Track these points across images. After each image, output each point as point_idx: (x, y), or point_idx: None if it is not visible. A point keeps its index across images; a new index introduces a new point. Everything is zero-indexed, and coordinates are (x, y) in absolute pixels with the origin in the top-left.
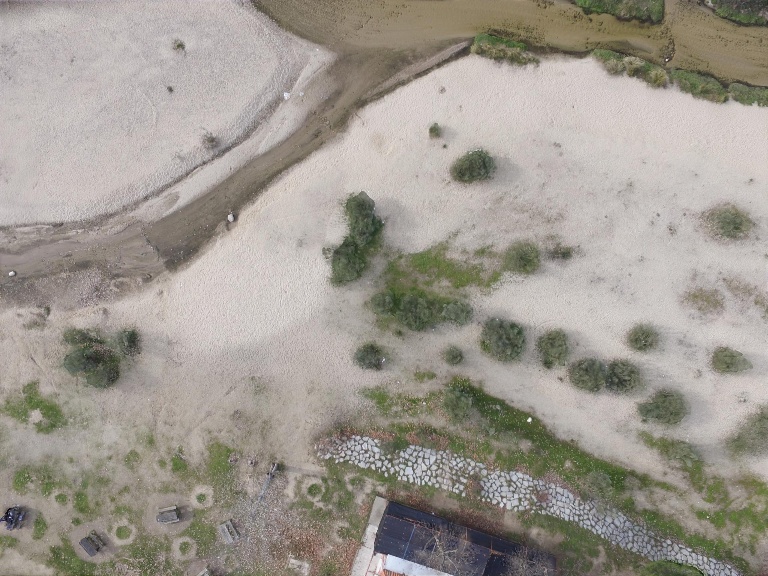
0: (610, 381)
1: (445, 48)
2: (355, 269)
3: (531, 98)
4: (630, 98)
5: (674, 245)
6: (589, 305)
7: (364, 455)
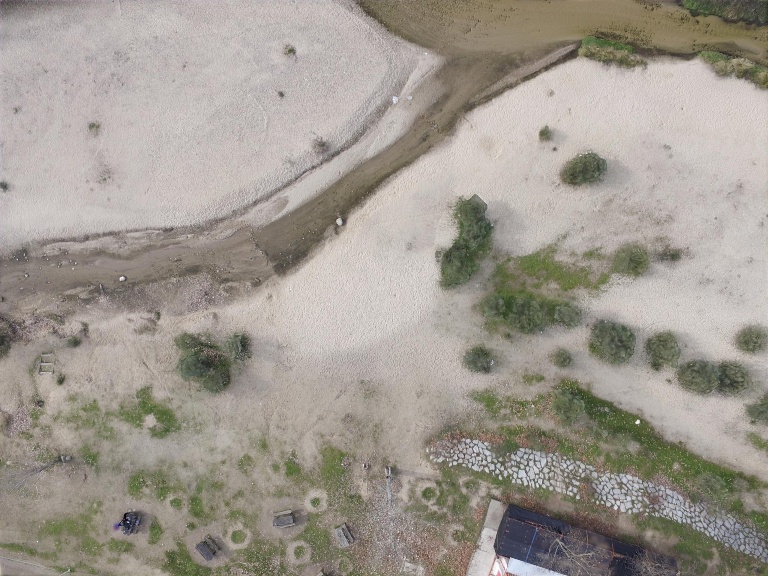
0: (720, 383)
1: (553, 51)
2: (468, 272)
3: (640, 100)
4: (739, 99)
5: None
6: (698, 307)
7: (476, 458)
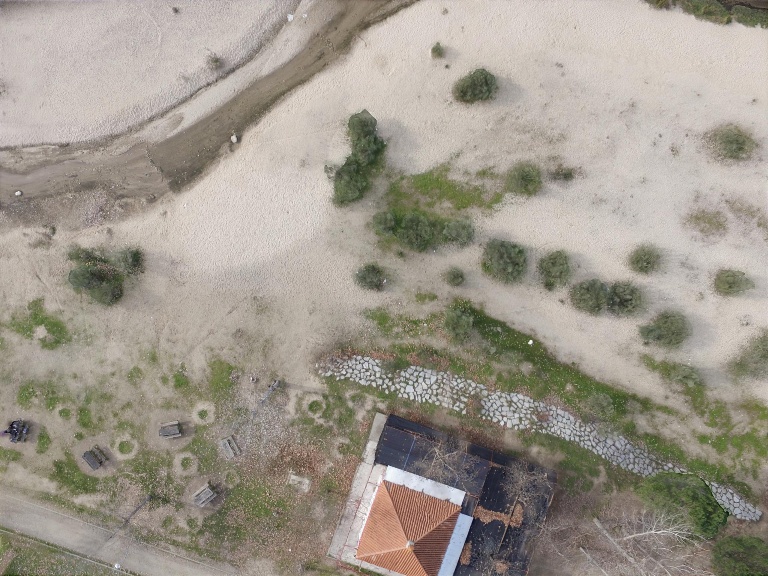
0: (611, 303)
1: None
2: (357, 187)
3: (533, 19)
4: (632, 19)
5: (676, 166)
6: (590, 227)
7: (365, 373)
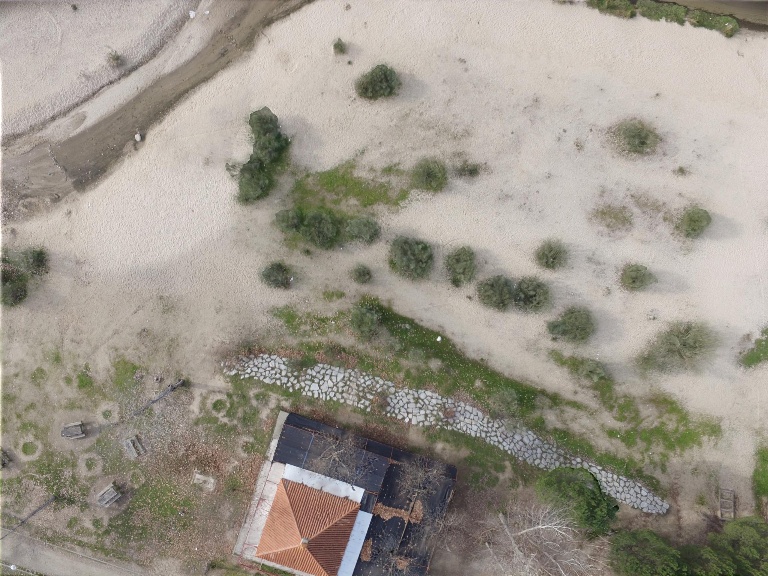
0: (518, 299)
1: None
2: (259, 185)
3: (436, 14)
4: (536, 14)
5: (581, 161)
6: (497, 223)
7: (270, 372)
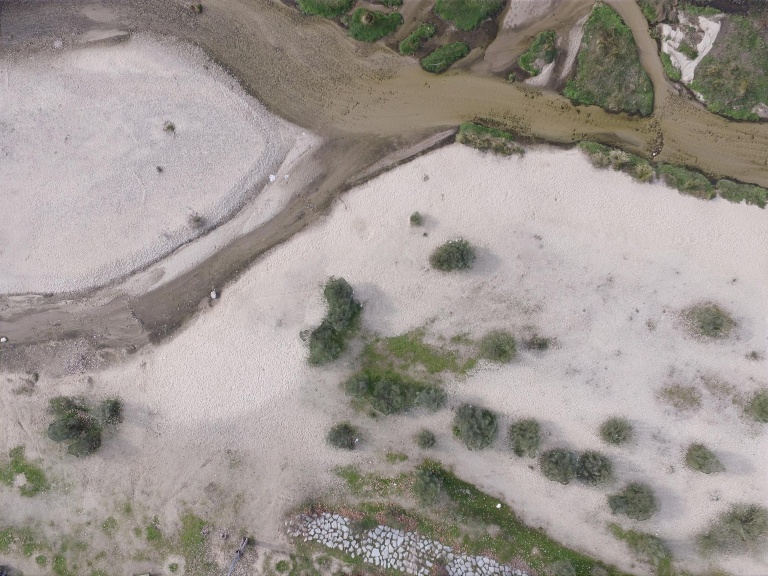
0: (581, 473)
1: (430, 135)
2: (331, 353)
3: (514, 189)
4: (614, 192)
5: (652, 341)
6: (563, 396)
7: (333, 534)
